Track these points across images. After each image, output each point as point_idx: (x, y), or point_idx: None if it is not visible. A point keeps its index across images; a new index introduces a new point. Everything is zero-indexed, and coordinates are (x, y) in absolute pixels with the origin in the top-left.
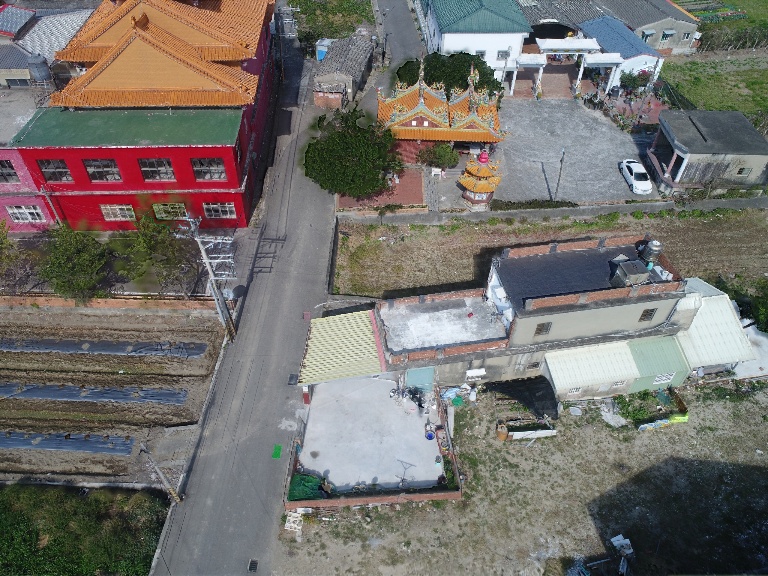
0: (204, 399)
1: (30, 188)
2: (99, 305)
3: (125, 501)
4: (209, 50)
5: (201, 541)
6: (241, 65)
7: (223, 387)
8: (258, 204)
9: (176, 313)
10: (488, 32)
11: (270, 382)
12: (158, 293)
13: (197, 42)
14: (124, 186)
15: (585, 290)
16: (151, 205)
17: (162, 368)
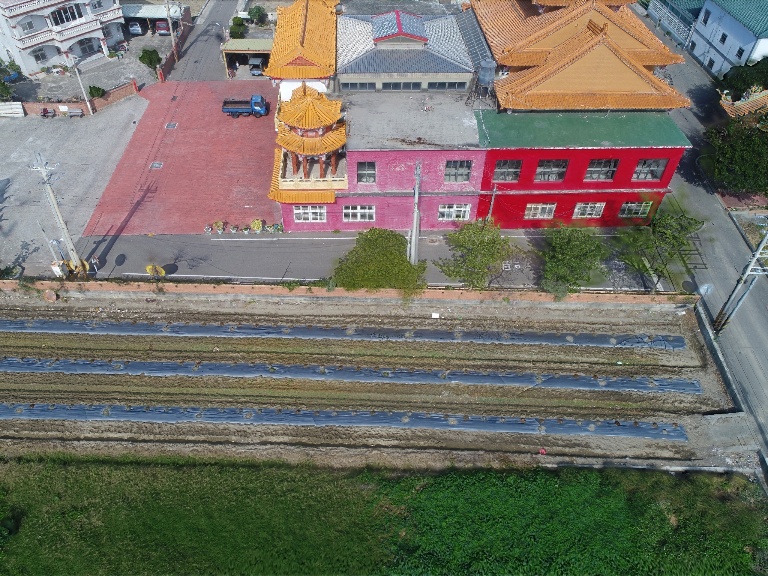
0: (719, 388)
1: (474, 187)
2: (568, 299)
3: (728, 483)
4: (635, 55)
5: None
6: (654, 69)
7: (744, 377)
8: None
9: (638, 307)
10: None
11: None
12: (613, 288)
13: (625, 47)
14: (562, 185)
15: None
16: (575, 204)
17: (657, 359)
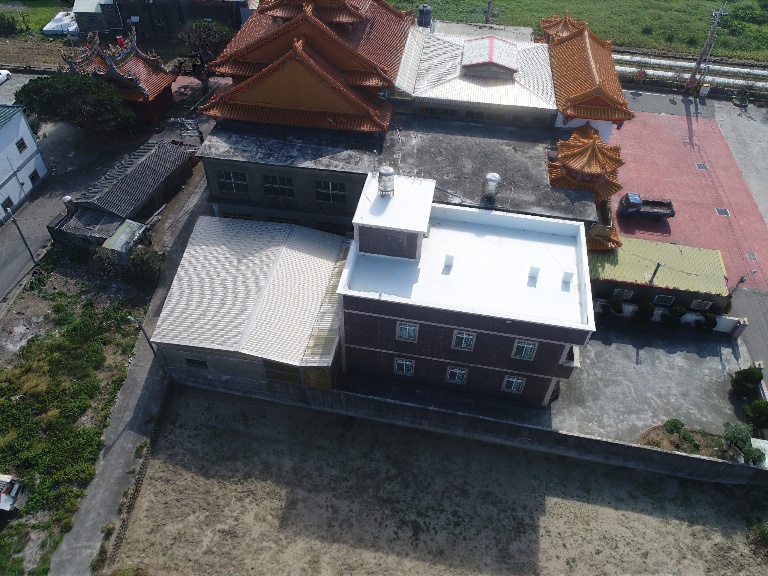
0: None
1: None
2: None
3: None
4: None
5: None
6: None
7: None
8: None
9: None
10: None
11: None
12: None
13: None
14: None
15: None
16: None
17: None
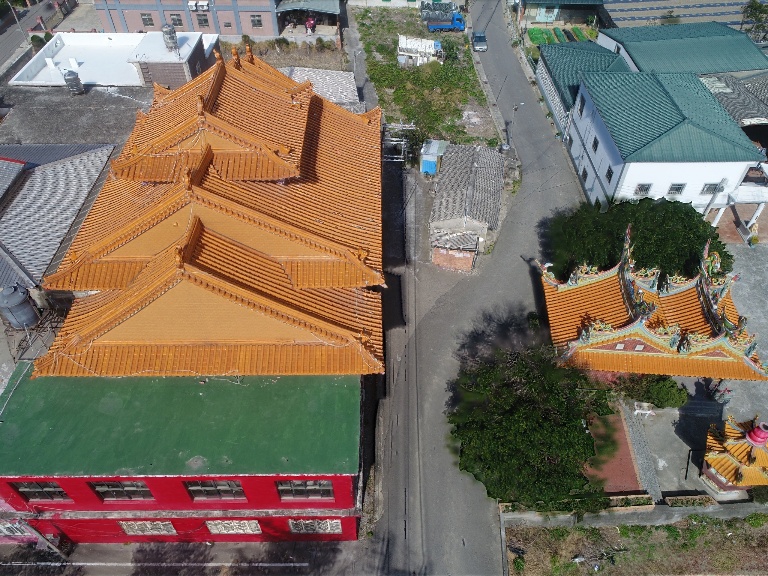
0: None
1: (1, 507)
2: None
3: None
4: (304, 266)
5: None
6: None
7: None
8: (369, 479)
9: None
10: (697, 161)
11: None
12: None
13: (284, 253)
14: (158, 505)
15: None
16: (203, 522)
17: None
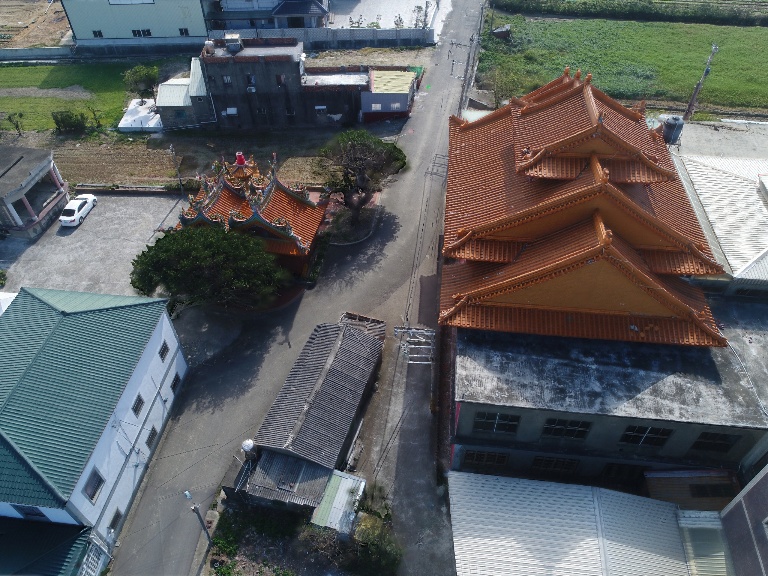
0: None
1: None
2: None
3: None
4: None
5: (458, 69)
6: None
7: None
8: None
9: None
10: None
11: (433, 107)
12: None
13: None
14: None
15: (260, 48)
16: None
17: None
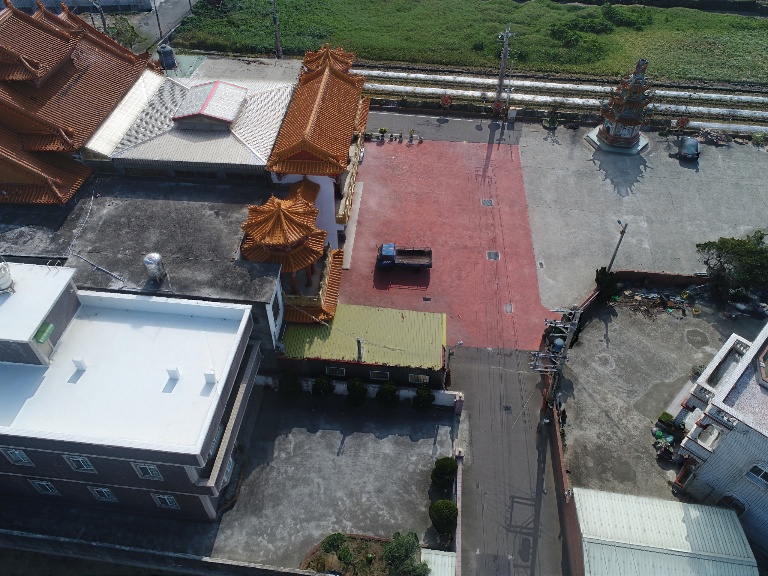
0: None
1: None
2: None
3: None
4: None
5: None
6: None
7: None
8: None
9: None
10: None
11: None
12: None
13: None
14: None
15: None
16: None
17: None
